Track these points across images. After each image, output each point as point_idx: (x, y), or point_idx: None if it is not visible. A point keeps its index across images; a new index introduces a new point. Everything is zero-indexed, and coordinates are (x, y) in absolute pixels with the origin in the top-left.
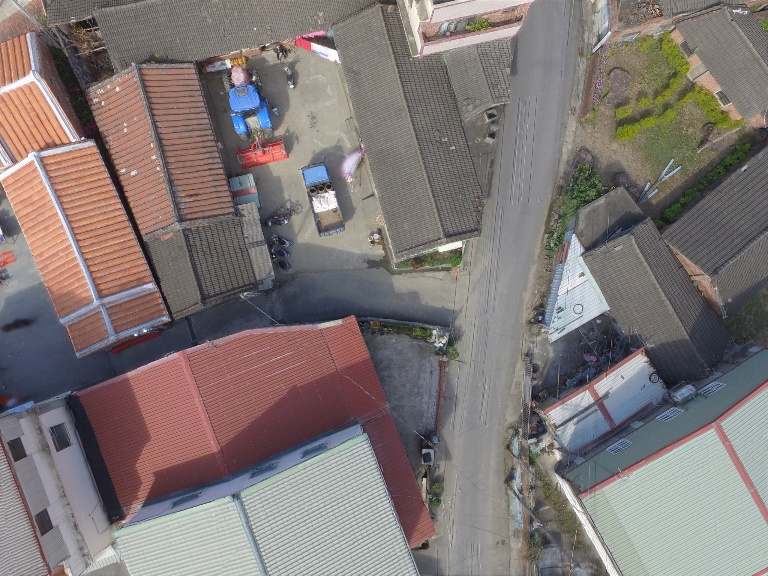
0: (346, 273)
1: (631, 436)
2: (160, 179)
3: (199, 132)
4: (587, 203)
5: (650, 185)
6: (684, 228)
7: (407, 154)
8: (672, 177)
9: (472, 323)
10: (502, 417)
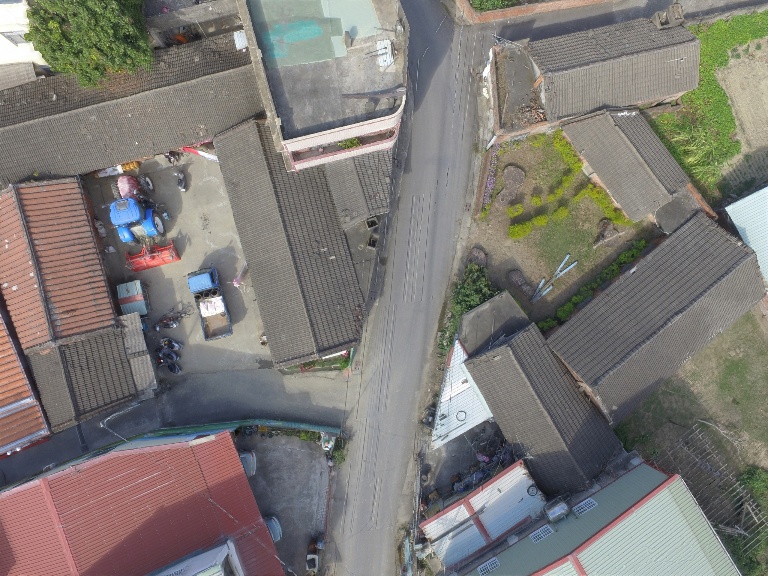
0: (237, 374)
1: (503, 555)
2: (37, 296)
3: (80, 246)
4: (471, 308)
5: (545, 282)
6: (569, 333)
7: (283, 267)
8: (568, 273)
9: (363, 423)
10: (393, 518)
